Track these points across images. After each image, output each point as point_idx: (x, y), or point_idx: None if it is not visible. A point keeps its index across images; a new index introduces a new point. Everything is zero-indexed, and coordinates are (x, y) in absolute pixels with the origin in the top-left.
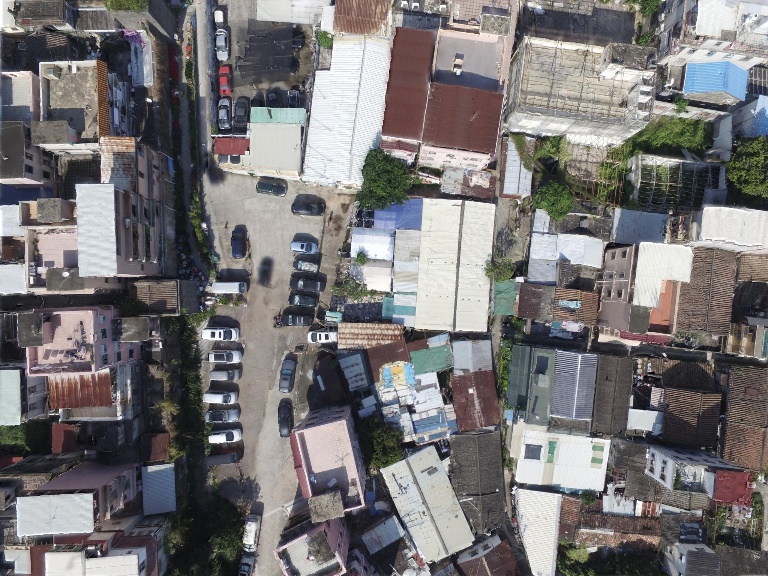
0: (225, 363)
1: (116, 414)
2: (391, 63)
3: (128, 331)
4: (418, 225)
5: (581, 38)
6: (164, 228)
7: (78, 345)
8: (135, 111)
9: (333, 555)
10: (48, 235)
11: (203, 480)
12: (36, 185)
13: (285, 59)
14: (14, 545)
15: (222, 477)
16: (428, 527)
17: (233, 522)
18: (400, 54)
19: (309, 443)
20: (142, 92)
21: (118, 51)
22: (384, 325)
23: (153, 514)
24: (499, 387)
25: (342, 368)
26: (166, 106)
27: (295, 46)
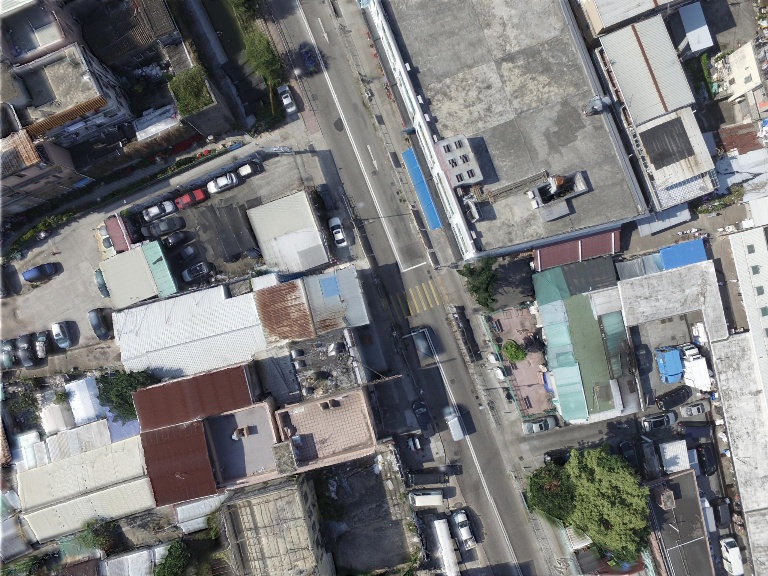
0: None
1: None
2: (202, 376)
3: None
4: (116, 439)
5: (367, 519)
6: (7, 205)
7: None
8: (111, 133)
9: None
10: None
11: None
12: None
13: (229, 249)
14: None
15: None
16: None
17: None
18: (215, 380)
19: None
20: (133, 131)
21: None
22: (6, 445)
23: None
24: (3, 571)
25: None
26: (137, 156)
27: (247, 252)
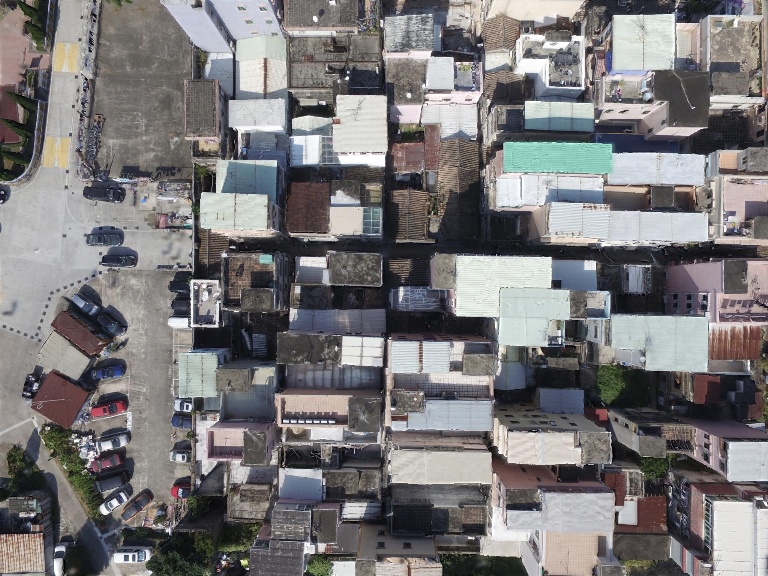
0: None
1: (736, 369)
2: None
3: None
4: None
5: None
6: None
7: (754, 296)
8: None
9: None
10: (733, 185)
11: None
12: (679, 137)
13: None
14: None
15: None
16: None
17: None
18: None
19: None
20: None
21: (693, 12)
22: None
23: None
24: None
25: None
26: None
27: None
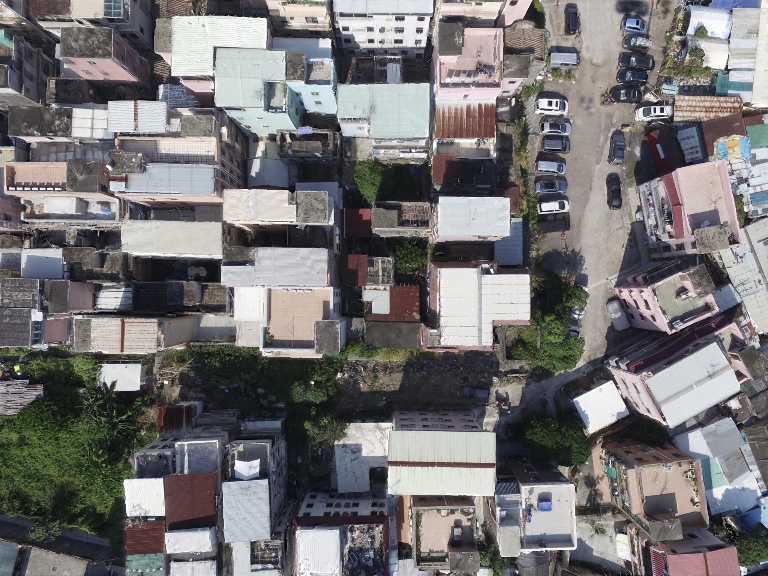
0: (557, 134)
1: None
2: None
3: (510, 68)
4: (757, 3)
5: None
6: None
7: (480, 67)
8: None
9: (714, 289)
10: None
11: (526, 252)
12: None
13: None
14: (374, 284)
15: (546, 249)
16: (763, 296)
17: (564, 288)
18: None
19: (683, 185)
20: None
21: None
22: (723, 98)
23: (503, 265)
24: None
25: (678, 140)
26: None
27: None
